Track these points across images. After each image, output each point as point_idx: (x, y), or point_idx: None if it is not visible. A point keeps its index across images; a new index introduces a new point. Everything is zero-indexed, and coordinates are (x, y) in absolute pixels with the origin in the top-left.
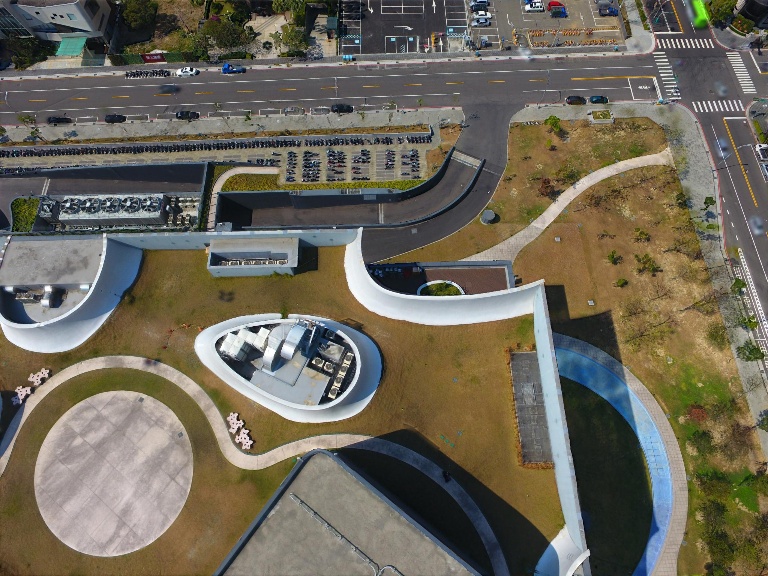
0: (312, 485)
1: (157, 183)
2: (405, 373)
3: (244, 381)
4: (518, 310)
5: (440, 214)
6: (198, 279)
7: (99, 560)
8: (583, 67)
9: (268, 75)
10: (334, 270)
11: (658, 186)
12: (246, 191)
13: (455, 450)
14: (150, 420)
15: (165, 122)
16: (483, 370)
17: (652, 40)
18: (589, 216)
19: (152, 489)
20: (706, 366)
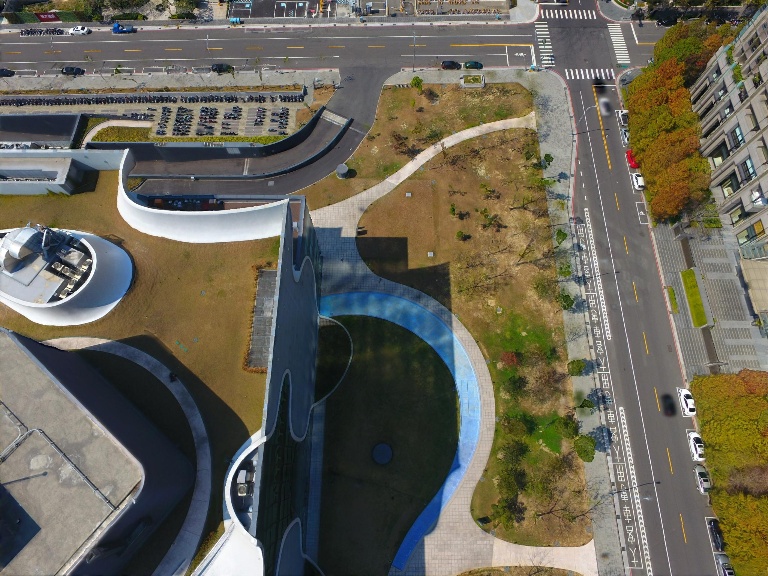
0: None
1: (39, 135)
2: (157, 285)
3: None
4: (273, 231)
5: (299, 168)
6: None
7: None
8: (464, 34)
9: (157, 36)
10: (109, 191)
11: (517, 148)
12: (113, 141)
13: (187, 355)
14: None
15: (51, 77)
16: (231, 285)
17: (536, 10)
18: (444, 174)
19: None
20: (533, 316)
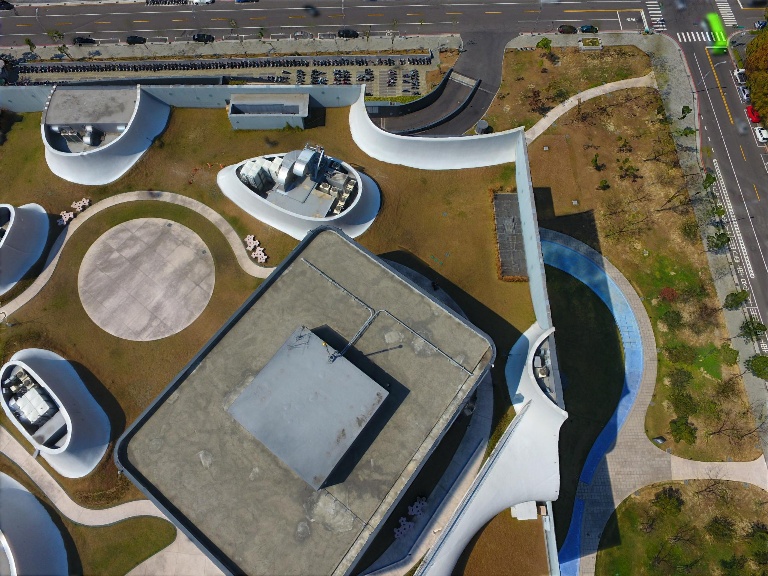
0: (320, 253)
1: None
2: (401, 208)
3: (261, 198)
4: (502, 158)
5: (438, 125)
6: (219, 131)
7: (135, 343)
8: (575, 1)
9: (279, 4)
10: (340, 126)
11: (641, 105)
12: None
13: (443, 267)
14: (177, 240)
15: (183, 44)
16: (469, 207)
17: None
18: (576, 129)
19: (180, 292)
20: (679, 258)
